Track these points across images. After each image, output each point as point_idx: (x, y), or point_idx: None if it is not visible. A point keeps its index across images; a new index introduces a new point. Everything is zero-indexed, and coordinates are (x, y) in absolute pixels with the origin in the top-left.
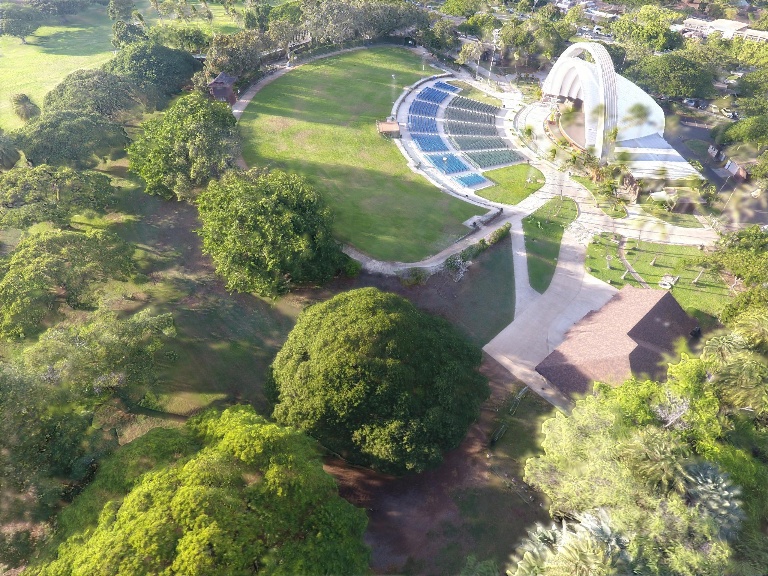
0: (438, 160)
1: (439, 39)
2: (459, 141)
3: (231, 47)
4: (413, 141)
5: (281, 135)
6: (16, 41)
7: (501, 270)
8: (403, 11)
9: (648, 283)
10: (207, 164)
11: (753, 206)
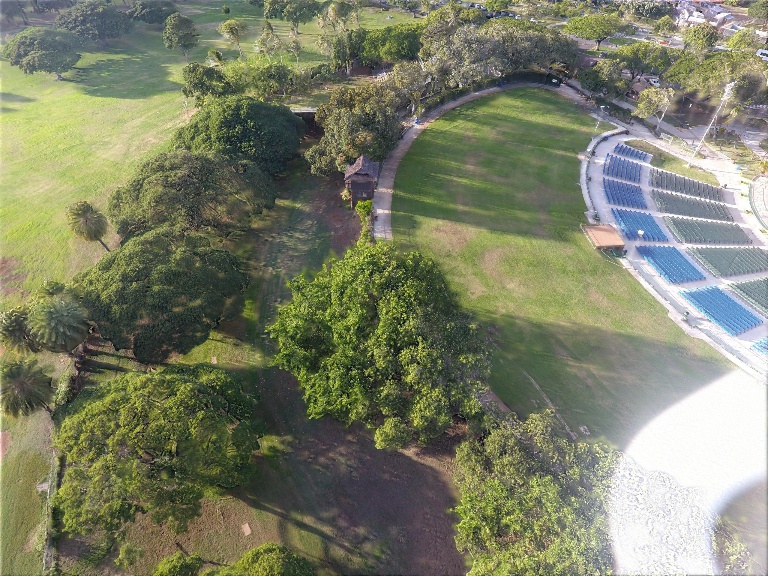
0: (709, 305)
1: (605, 81)
2: (710, 259)
3: (363, 111)
4: (646, 261)
5: (462, 259)
6: (49, 75)
7: None
8: (552, 42)
9: None
10: (445, 403)
11: None
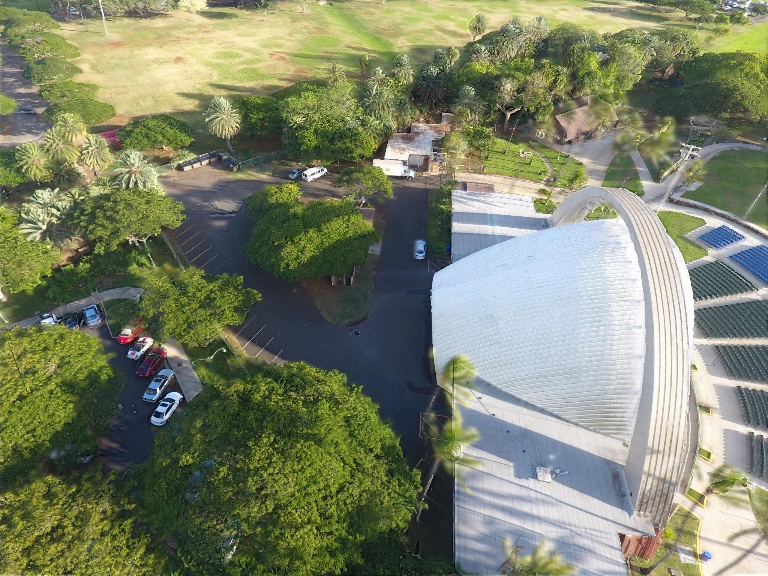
0: None
1: None
2: None
3: None
4: None
5: None
6: None
7: (655, 159)
8: None
9: (539, 156)
10: None
11: (389, 202)
